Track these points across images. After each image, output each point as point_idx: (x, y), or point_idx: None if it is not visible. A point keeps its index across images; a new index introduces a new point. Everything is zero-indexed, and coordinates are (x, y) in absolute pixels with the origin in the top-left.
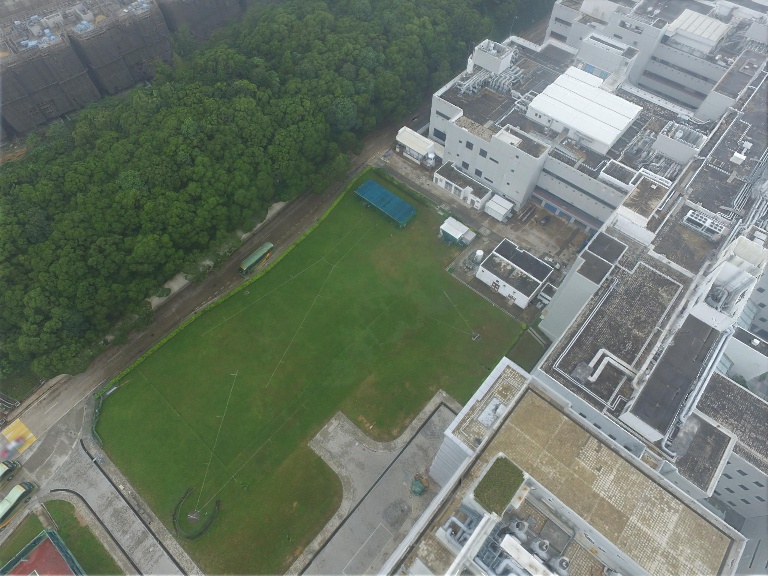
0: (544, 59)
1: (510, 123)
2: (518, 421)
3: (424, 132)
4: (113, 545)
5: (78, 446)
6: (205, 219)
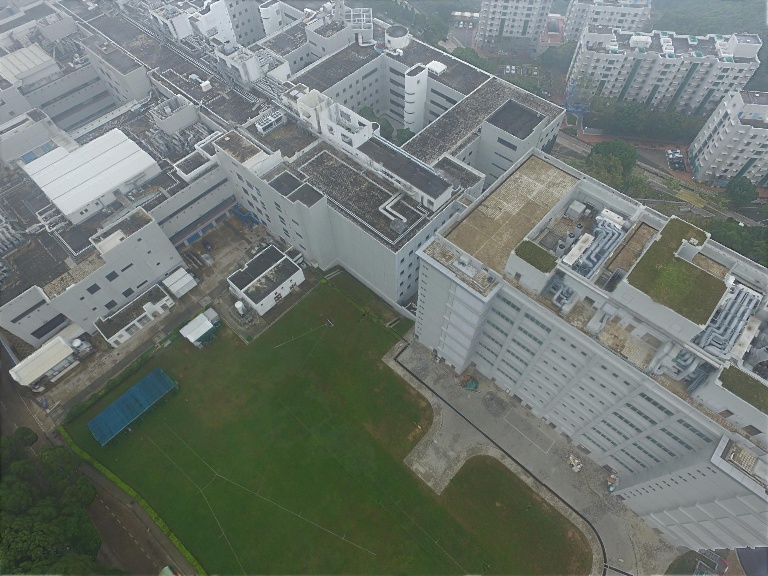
0: None
1: (79, 242)
2: (470, 251)
3: (17, 357)
4: None
5: None
6: None
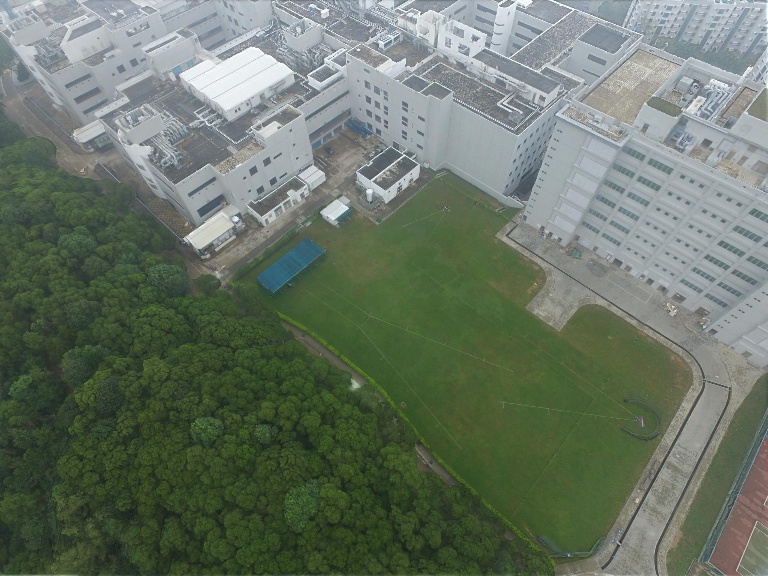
0: (144, 99)
1: (235, 134)
2: None
3: None
4: (687, 495)
5: (610, 570)
6: (352, 410)
